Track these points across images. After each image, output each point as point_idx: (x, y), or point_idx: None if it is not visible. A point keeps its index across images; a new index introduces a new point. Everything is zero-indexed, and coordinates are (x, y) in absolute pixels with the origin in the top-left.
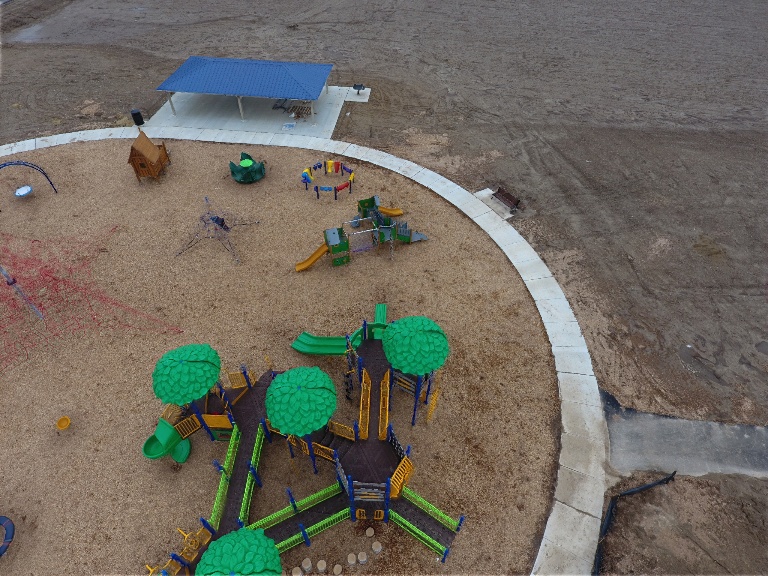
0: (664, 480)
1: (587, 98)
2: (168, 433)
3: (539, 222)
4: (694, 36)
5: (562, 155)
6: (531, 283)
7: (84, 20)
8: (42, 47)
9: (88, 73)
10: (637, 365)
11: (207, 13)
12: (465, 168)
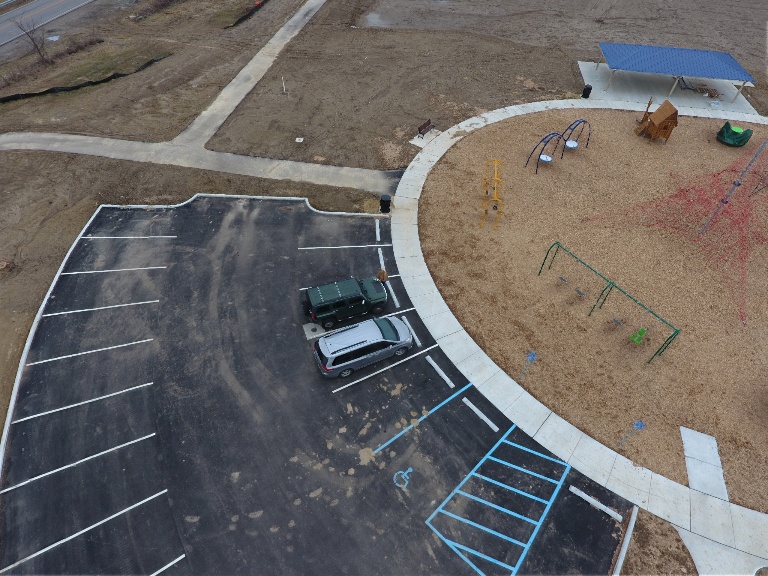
0: None
1: None
2: None
3: None
4: None
5: None
6: None
7: (409, 10)
8: (420, 31)
9: (490, 54)
10: None
11: (508, 7)
12: None
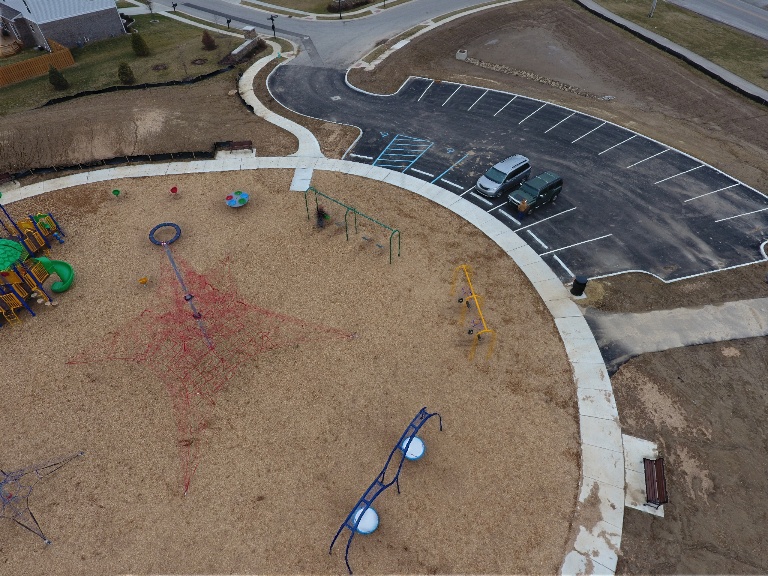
0: None
1: None
2: None
3: None
4: None
5: None
6: None
7: None
8: None
9: None
10: None
11: None
12: None
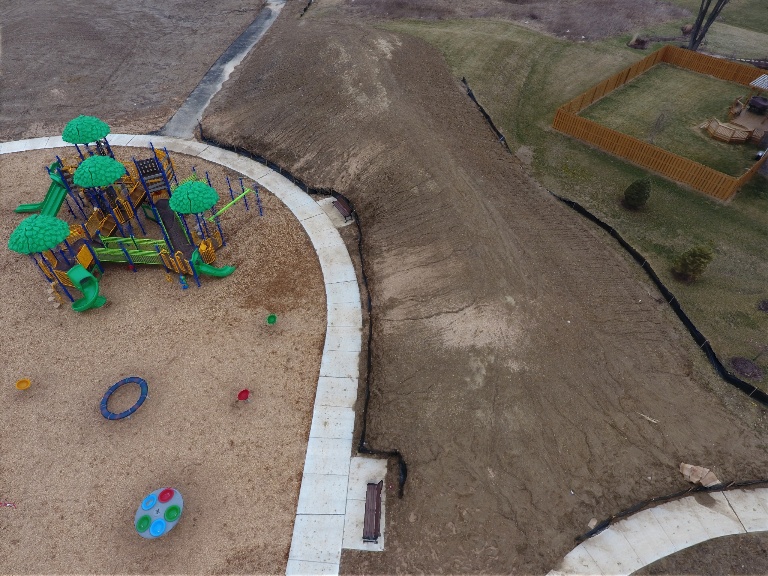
0: None
1: None
2: (83, 270)
3: None
4: None
5: None
6: (49, 146)
7: None
8: None
9: None
10: (137, 120)
11: None
12: None
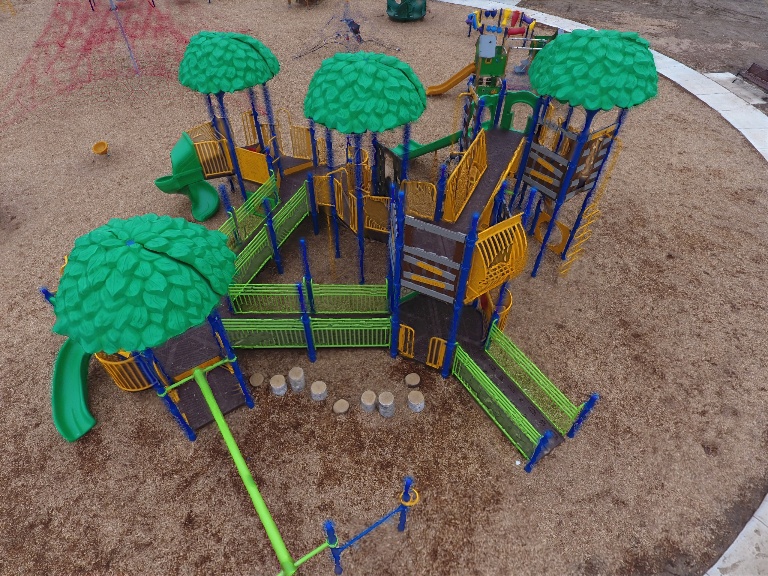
0: None
1: None
2: (185, 150)
3: None
4: None
5: None
6: None
7: None
8: None
9: None
10: None
11: None
12: (697, 50)
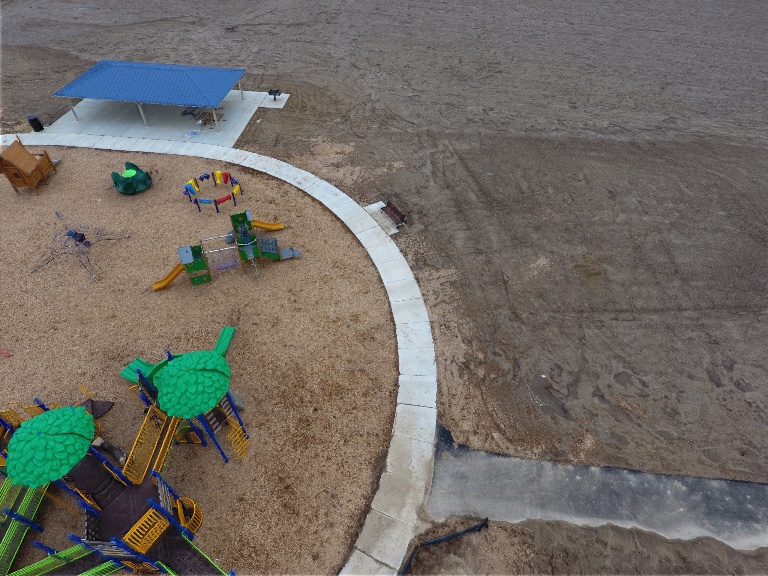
0: (476, 527)
1: (512, 106)
2: None
3: (423, 238)
4: (640, 41)
5: (466, 167)
6: (397, 305)
7: (19, 20)
8: None
9: (1, 76)
10: (483, 397)
11: (148, 13)
12: (363, 180)
